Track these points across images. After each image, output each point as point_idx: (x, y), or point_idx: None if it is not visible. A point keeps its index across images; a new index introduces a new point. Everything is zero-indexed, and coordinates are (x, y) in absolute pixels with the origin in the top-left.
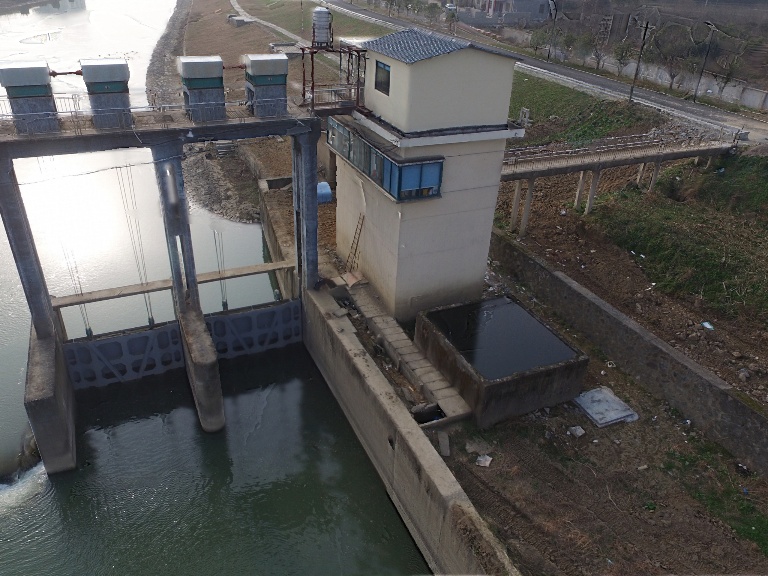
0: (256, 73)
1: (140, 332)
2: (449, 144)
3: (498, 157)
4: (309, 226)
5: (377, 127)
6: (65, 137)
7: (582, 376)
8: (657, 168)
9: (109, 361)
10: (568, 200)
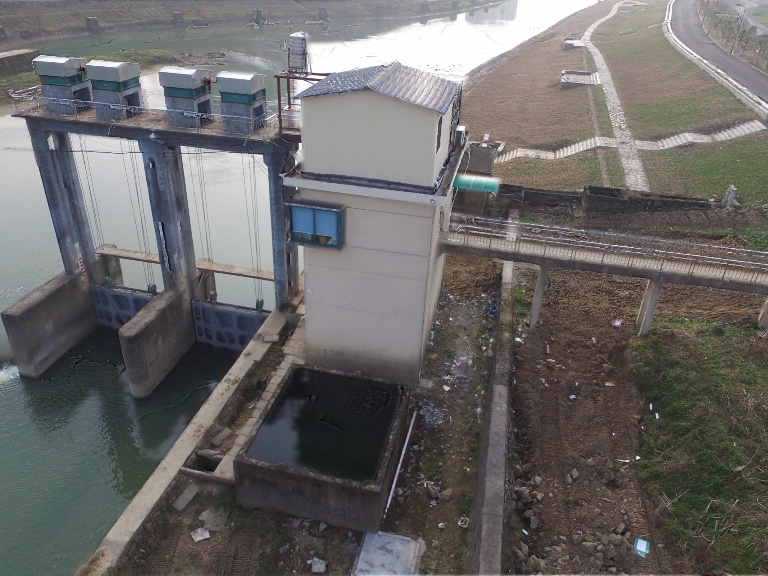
0: (221, 89)
1: (142, 295)
2: (344, 194)
3: (422, 223)
4: (275, 246)
5: None
6: (66, 120)
7: (373, 509)
8: None
9: (121, 310)
10: None
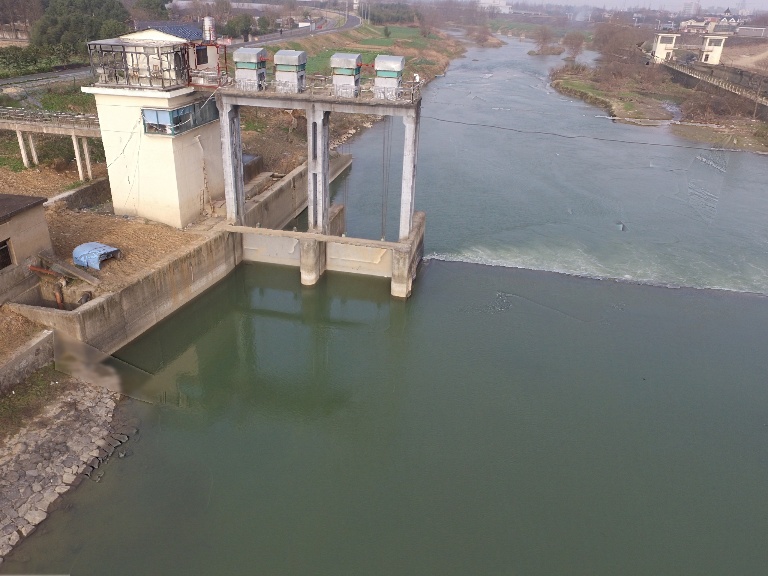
0: None
1: None
2: None
3: None
4: None
5: None
6: None
7: None
8: None
9: None
10: (8, 172)
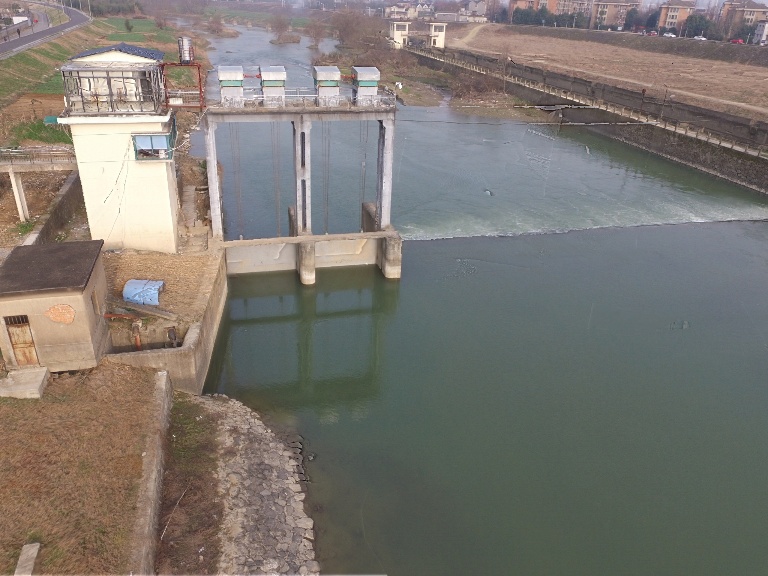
0: None
1: None
2: None
3: None
4: None
5: None
6: None
7: None
8: None
9: None
10: None
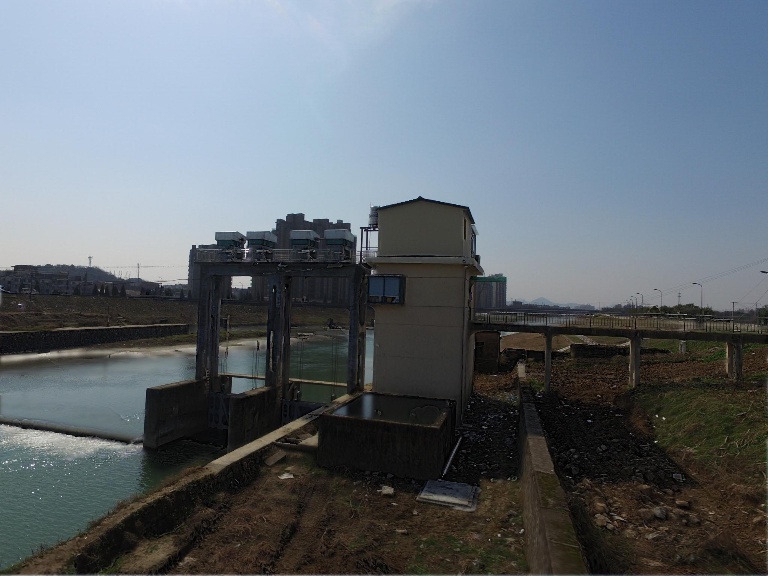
0: (326, 237)
1: None
2: (405, 264)
3: (457, 283)
4: (351, 342)
5: None
6: (227, 262)
7: (433, 451)
8: (737, 350)
9: (227, 412)
10: None
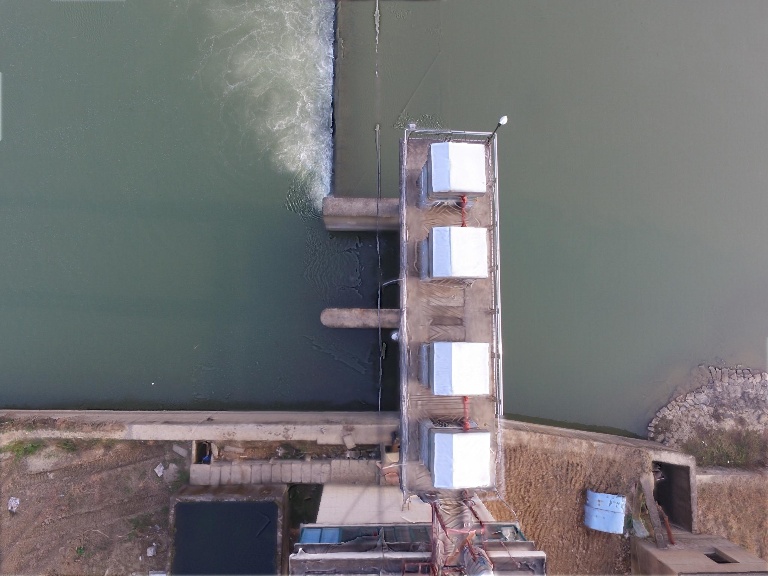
0: None
1: None
2: None
3: None
4: None
5: (353, 555)
6: None
7: None
8: None
9: None
10: None
